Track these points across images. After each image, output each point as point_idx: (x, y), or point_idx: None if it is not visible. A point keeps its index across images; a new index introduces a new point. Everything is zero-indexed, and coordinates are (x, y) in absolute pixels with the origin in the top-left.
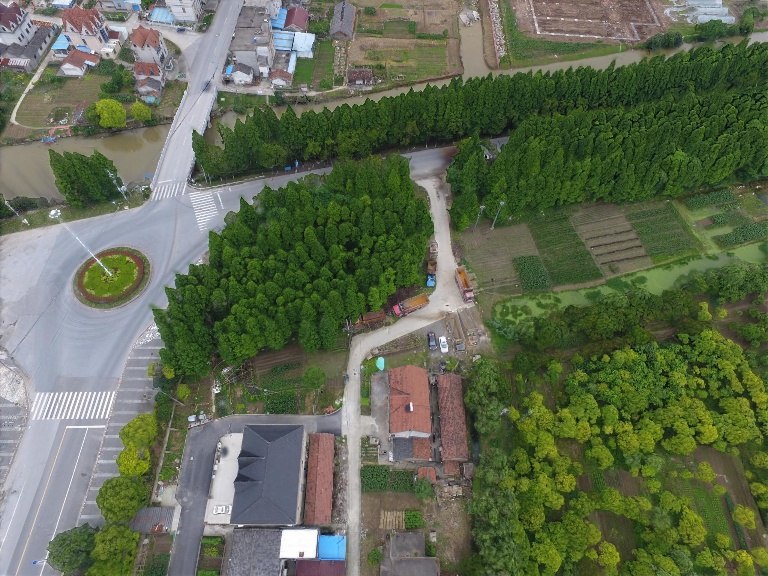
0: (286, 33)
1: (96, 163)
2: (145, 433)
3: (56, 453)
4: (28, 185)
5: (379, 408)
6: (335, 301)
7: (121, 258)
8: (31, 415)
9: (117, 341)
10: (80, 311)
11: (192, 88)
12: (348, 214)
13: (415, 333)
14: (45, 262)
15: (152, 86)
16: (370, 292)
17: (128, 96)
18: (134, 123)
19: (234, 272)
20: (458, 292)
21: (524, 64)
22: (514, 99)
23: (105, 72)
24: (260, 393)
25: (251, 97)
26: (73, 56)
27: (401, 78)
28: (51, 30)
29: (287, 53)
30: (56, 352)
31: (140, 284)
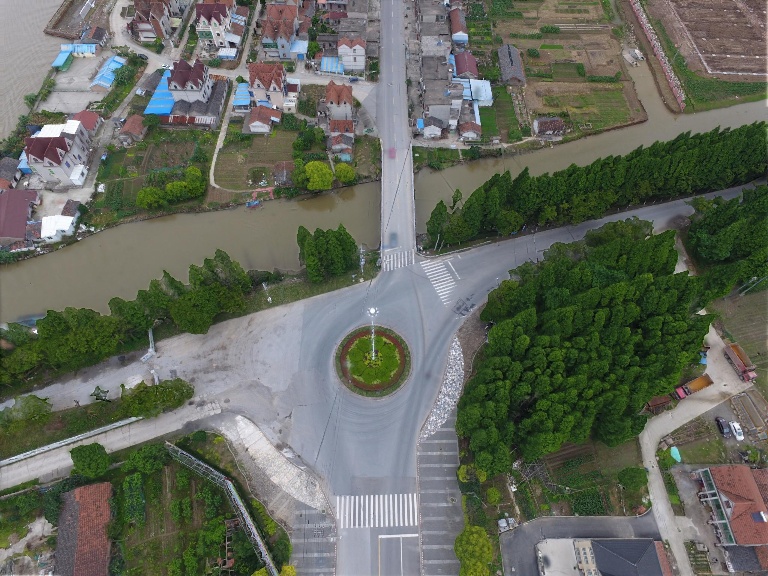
0: (461, 81)
1: (346, 239)
2: (491, 552)
3: (377, 568)
4: (234, 251)
5: (692, 507)
6: (643, 393)
7: (377, 339)
8: (338, 523)
9: (400, 434)
10: (352, 400)
11: (385, 144)
12: (632, 293)
13: (705, 419)
14: (299, 344)
15: (347, 143)
16: (670, 380)
17: (322, 154)
18: (334, 183)
19: (540, 364)
20: (731, 369)
21: (707, 107)
22: (744, 154)
23: (290, 128)
24: (563, 492)
25: (443, 151)
26: (260, 113)
27: (588, 126)
28: (226, 84)
29: (469, 103)
30: (342, 448)
31: (404, 368)
